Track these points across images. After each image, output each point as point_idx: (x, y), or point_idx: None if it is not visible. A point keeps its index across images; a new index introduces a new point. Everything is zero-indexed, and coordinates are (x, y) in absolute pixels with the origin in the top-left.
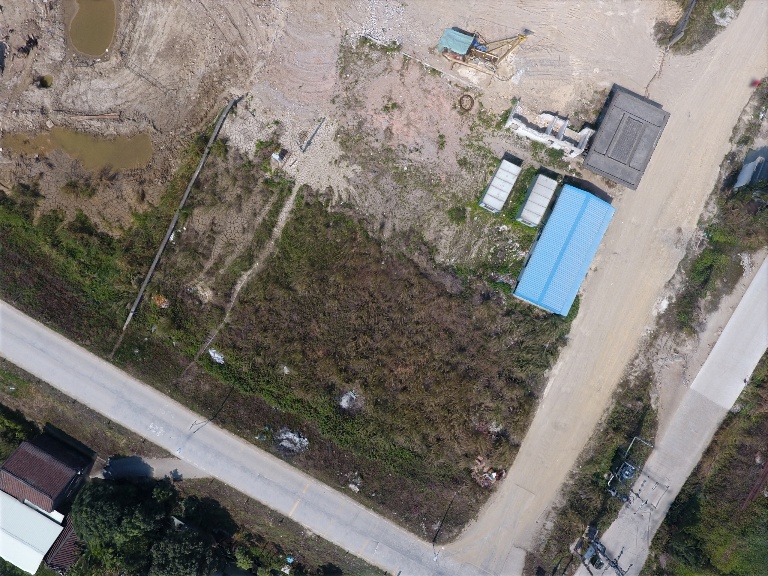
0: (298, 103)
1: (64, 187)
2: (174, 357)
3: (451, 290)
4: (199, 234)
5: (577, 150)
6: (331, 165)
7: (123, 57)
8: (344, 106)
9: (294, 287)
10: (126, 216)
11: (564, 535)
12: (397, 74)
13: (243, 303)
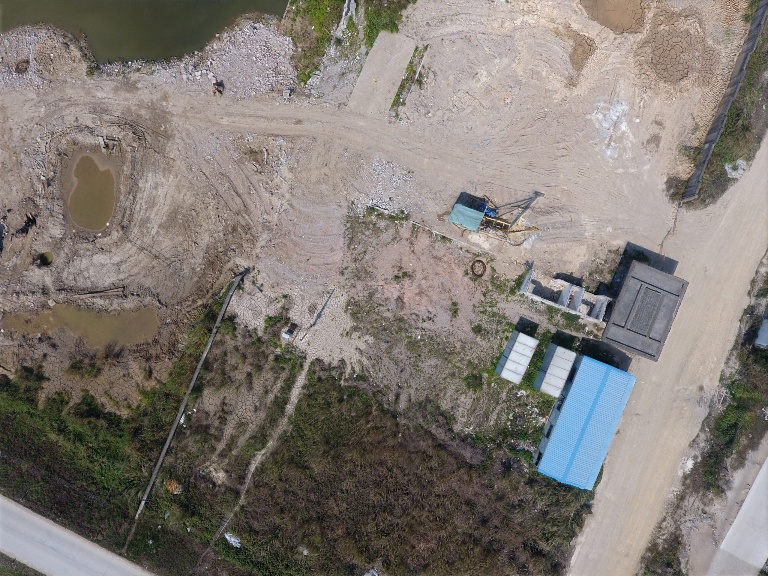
0: (306, 276)
1: (69, 371)
2: (189, 544)
3: (471, 461)
4: (210, 415)
5: (595, 320)
6: (343, 337)
7: (124, 231)
8: (353, 278)
9: (310, 465)
10: (134, 394)
11: None
12: (406, 242)
13: (258, 487)
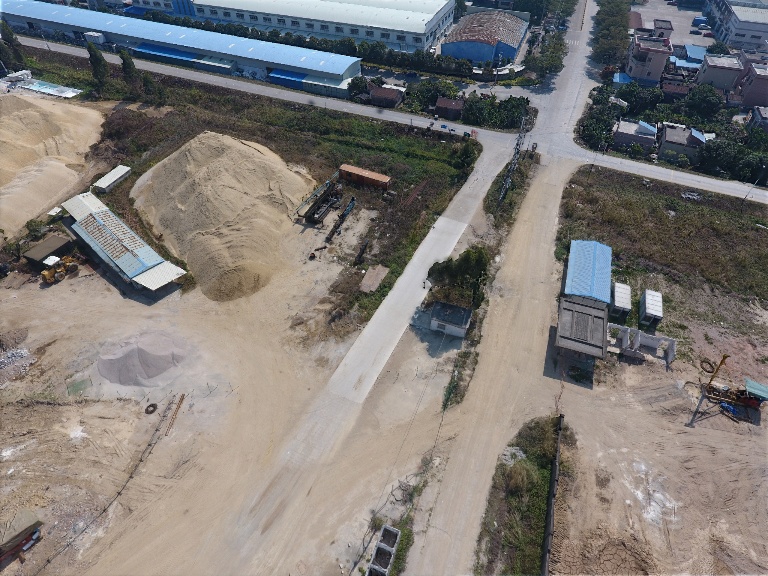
0: None
1: None
2: None
3: None
4: None
5: (612, 324)
6: None
7: None
8: None
9: None
10: None
11: (525, 168)
12: None
13: None
